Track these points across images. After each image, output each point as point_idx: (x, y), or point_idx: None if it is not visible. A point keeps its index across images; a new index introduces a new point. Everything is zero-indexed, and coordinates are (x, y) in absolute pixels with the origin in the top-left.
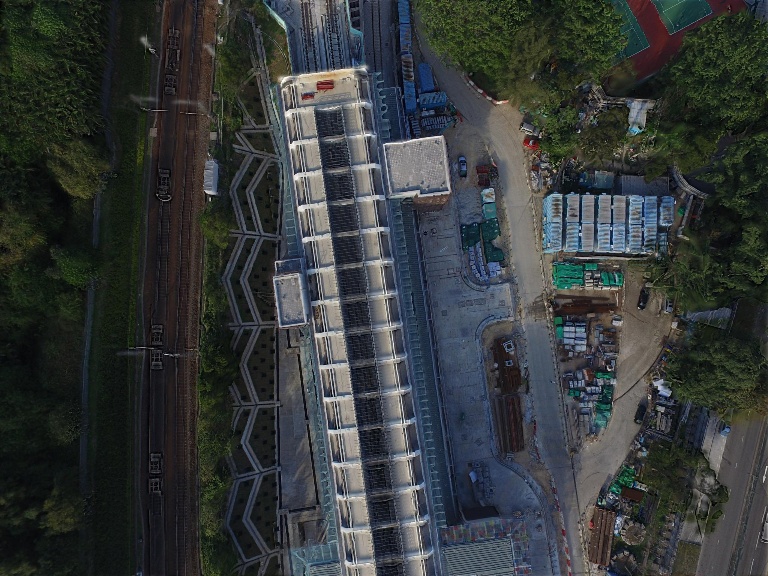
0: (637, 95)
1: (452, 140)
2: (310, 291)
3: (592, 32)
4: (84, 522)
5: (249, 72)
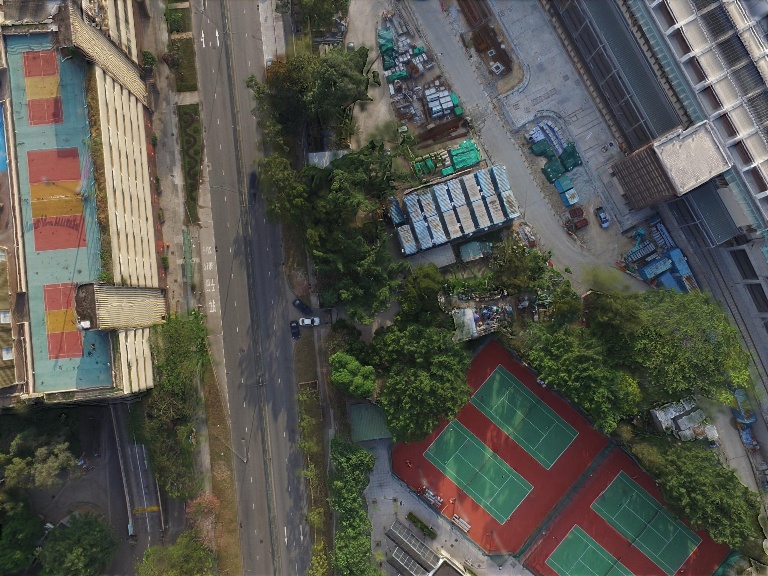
0: (466, 347)
1: (619, 241)
2: None
3: (569, 356)
4: None
5: None
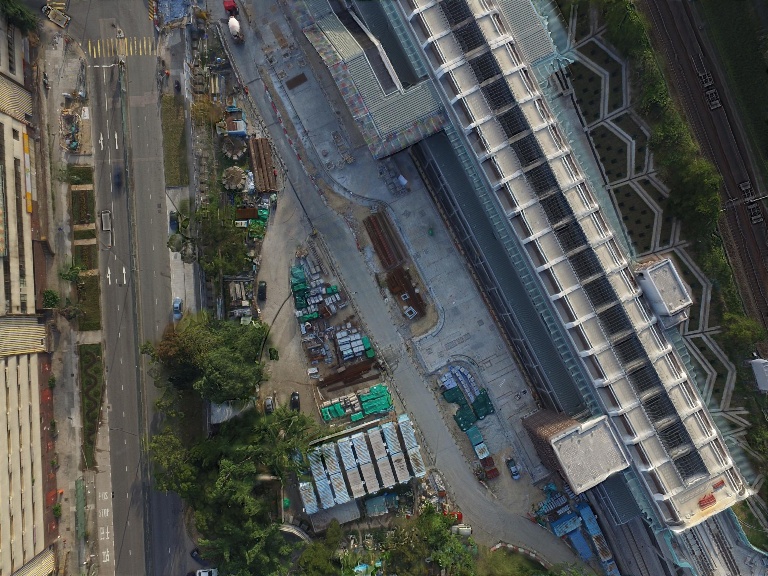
0: None
1: (531, 491)
2: (646, 302)
3: None
4: (767, 29)
5: (759, 488)
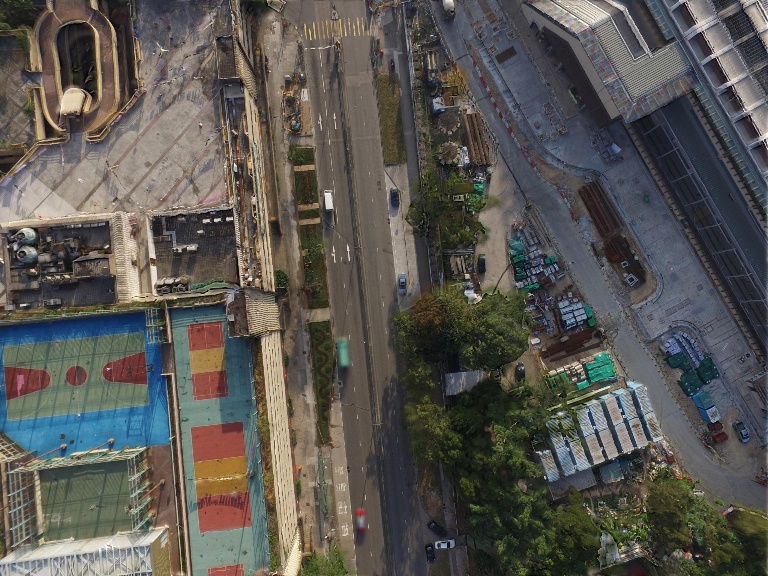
0: (607, 570)
1: (759, 455)
2: None
3: None
4: None
5: None
